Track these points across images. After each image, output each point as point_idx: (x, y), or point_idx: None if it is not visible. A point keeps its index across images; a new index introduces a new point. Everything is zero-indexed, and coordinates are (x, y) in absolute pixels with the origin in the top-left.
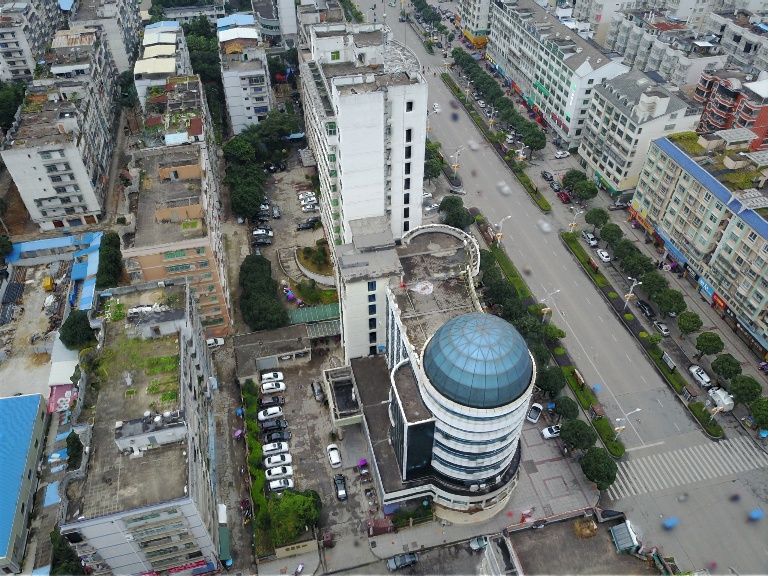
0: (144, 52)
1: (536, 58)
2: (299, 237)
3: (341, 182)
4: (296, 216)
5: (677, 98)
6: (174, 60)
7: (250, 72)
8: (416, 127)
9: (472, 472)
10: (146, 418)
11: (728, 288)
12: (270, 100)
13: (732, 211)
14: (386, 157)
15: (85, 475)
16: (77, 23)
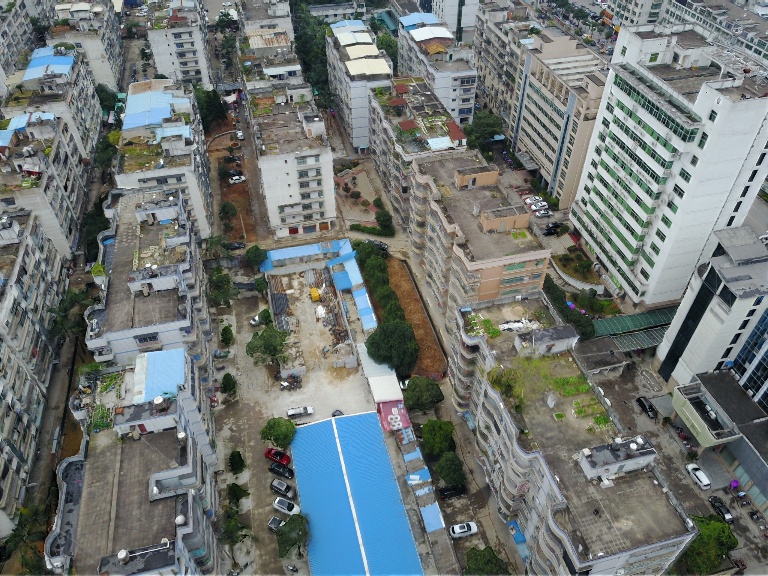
0: (348, 52)
1: None
2: None
3: (683, 190)
4: None
5: None
6: (384, 61)
7: (463, 73)
8: None
9: None
10: (616, 445)
11: None
12: (474, 101)
13: None
14: None
15: (566, 506)
16: (253, 22)
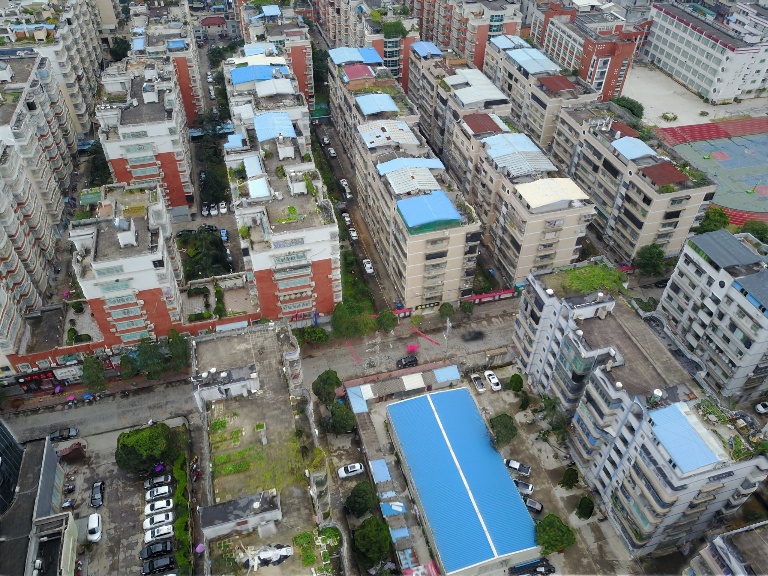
0: None
1: None
2: None
3: None
4: None
5: None
6: None
7: None
8: None
9: None
10: None
11: None
12: None
13: None
14: None
15: None
16: None
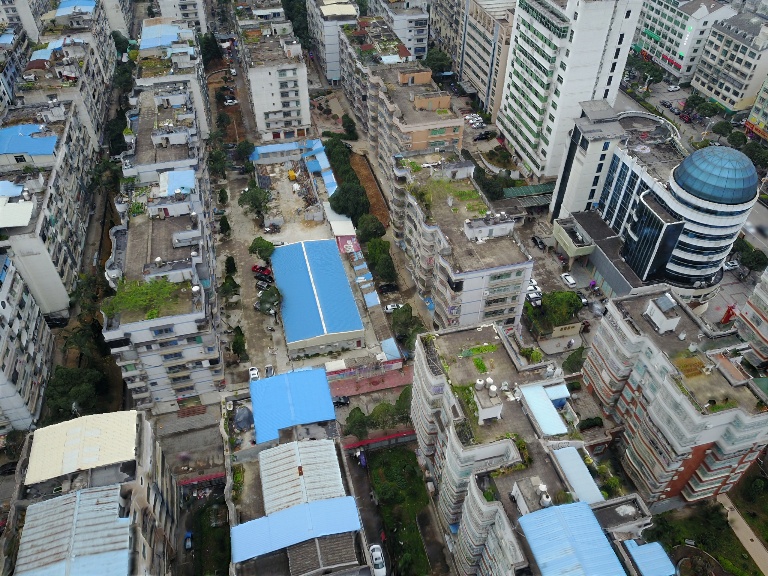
0: (323, 0)
1: (647, 9)
2: (478, 145)
3: (562, 78)
4: (469, 131)
5: None
6: (352, 6)
7: (417, 16)
8: (628, 32)
9: (700, 268)
10: (487, 216)
11: None
12: None
13: None
14: None
15: (451, 252)
16: None
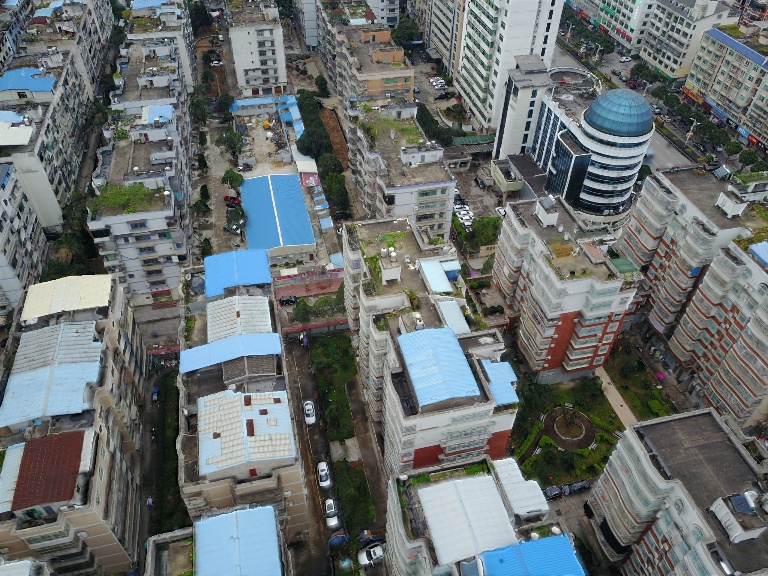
0: None
1: None
2: (438, 104)
3: (503, 36)
4: (431, 92)
5: (722, 4)
6: None
7: None
8: None
9: (608, 197)
10: (420, 144)
11: (760, 127)
12: None
13: (765, 69)
14: (537, 16)
15: (388, 173)
16: None
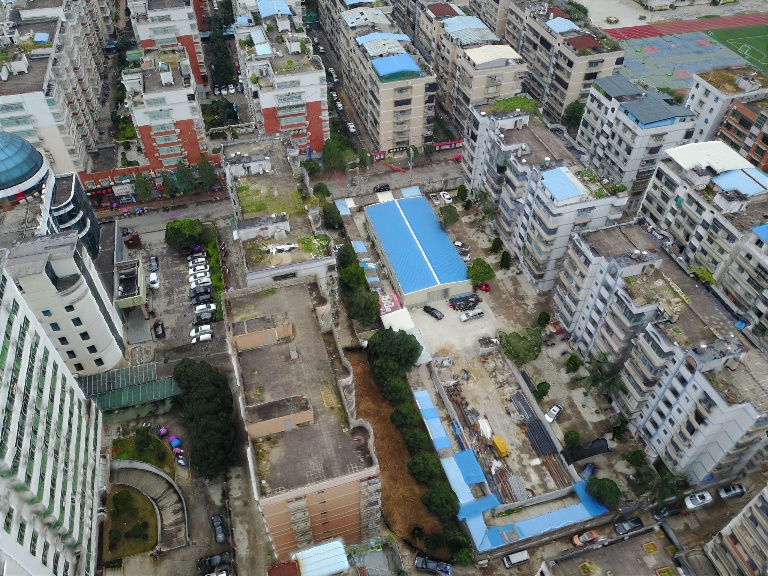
0: None
1: None
2: None
3: None
4: None
5: None
6: None
7: None
8: None
9: None
10: (248, 157)
11: None
12: None
13: None
14: None
15: None
16: None
